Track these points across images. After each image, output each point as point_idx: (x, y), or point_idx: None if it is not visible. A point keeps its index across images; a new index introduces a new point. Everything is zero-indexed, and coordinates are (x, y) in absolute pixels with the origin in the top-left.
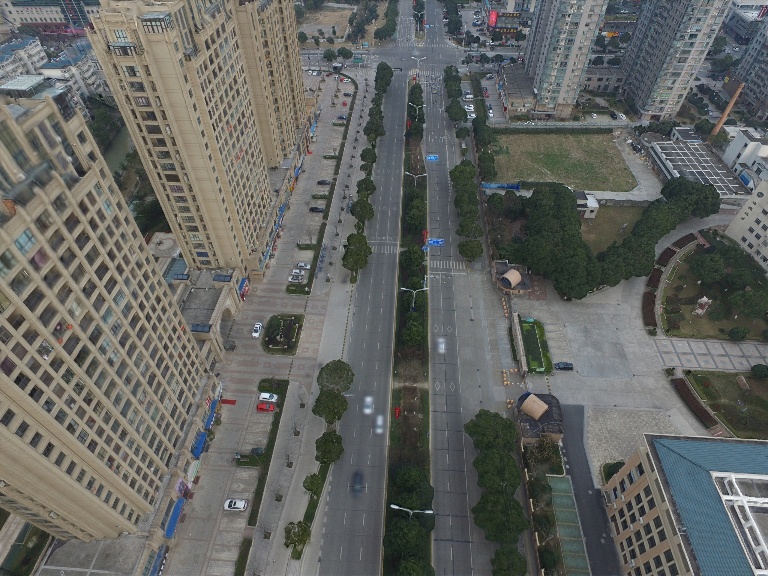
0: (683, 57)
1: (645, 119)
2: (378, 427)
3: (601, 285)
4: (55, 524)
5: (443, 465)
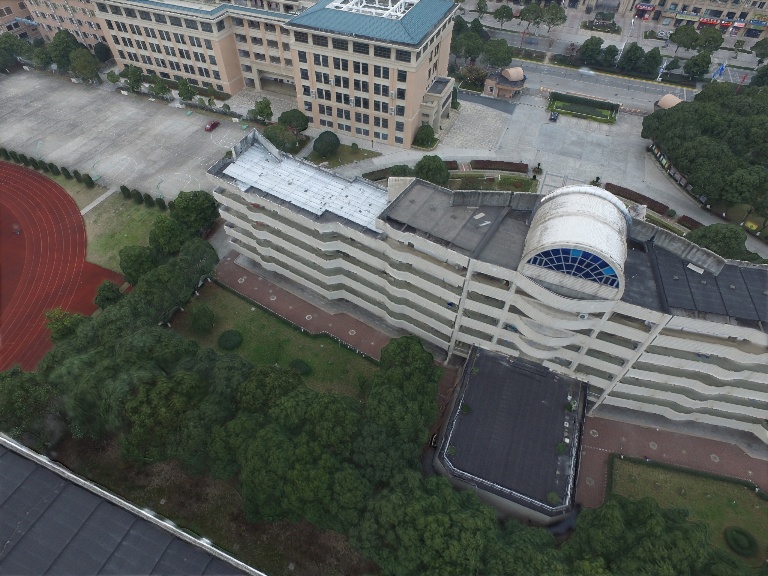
0: None
1: None
2: (516, 44)
3: (674, 168)
4: None
5: None
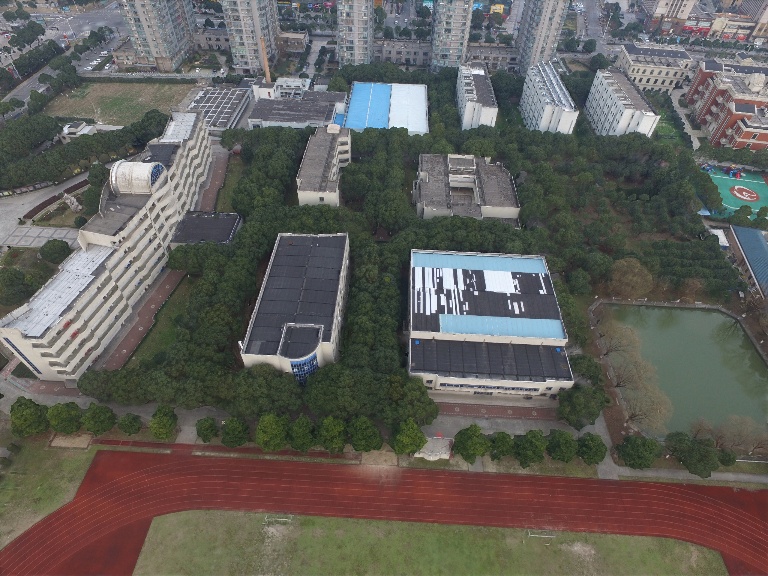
0: (235, 15)
1: (239, 73)
2: None
3: (16, 189)
4: None
5: None
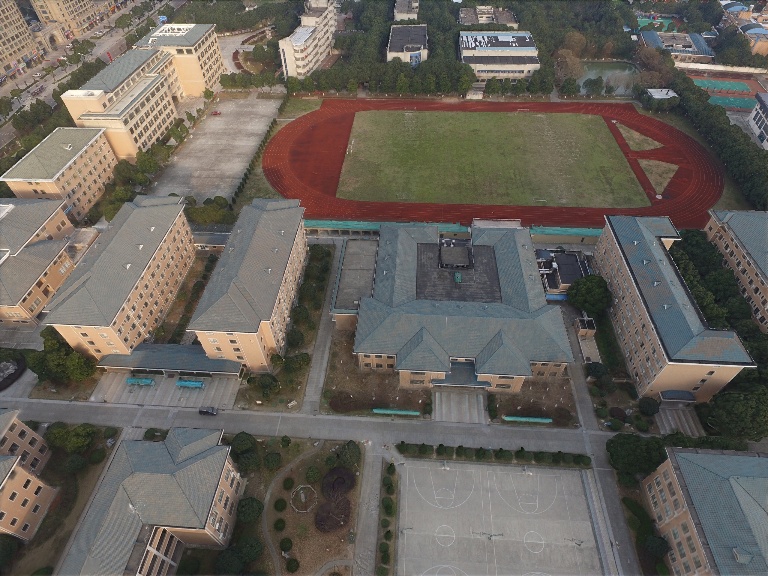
0: None
1: None
2: None
3: (233, 32)
4: None
5: None
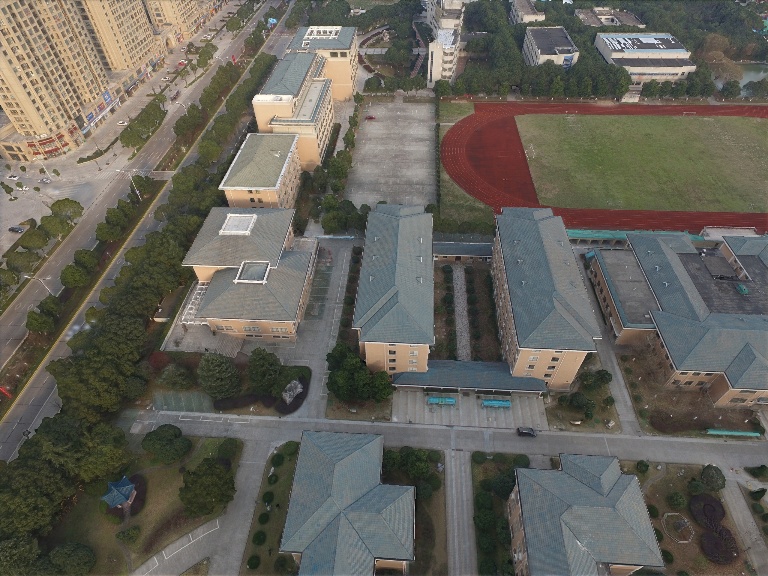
0: None
1: None
2: None
3: None
4: (101, 48)
5: (249, 73)
